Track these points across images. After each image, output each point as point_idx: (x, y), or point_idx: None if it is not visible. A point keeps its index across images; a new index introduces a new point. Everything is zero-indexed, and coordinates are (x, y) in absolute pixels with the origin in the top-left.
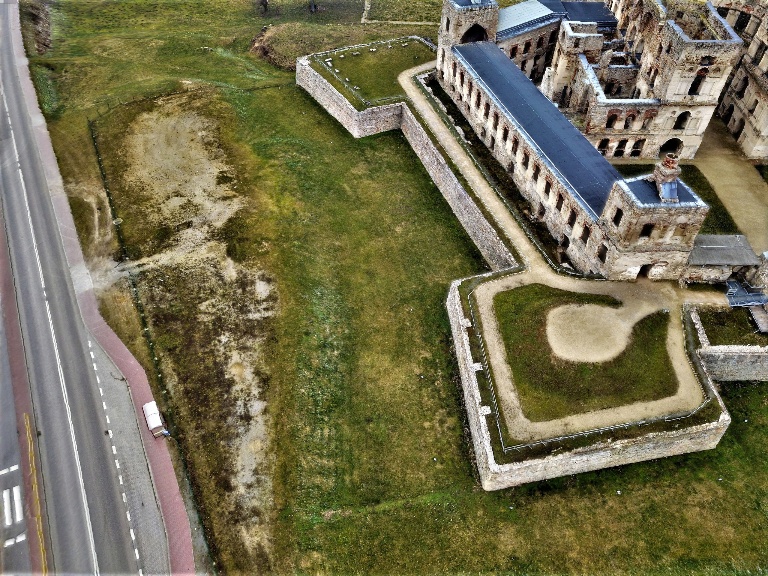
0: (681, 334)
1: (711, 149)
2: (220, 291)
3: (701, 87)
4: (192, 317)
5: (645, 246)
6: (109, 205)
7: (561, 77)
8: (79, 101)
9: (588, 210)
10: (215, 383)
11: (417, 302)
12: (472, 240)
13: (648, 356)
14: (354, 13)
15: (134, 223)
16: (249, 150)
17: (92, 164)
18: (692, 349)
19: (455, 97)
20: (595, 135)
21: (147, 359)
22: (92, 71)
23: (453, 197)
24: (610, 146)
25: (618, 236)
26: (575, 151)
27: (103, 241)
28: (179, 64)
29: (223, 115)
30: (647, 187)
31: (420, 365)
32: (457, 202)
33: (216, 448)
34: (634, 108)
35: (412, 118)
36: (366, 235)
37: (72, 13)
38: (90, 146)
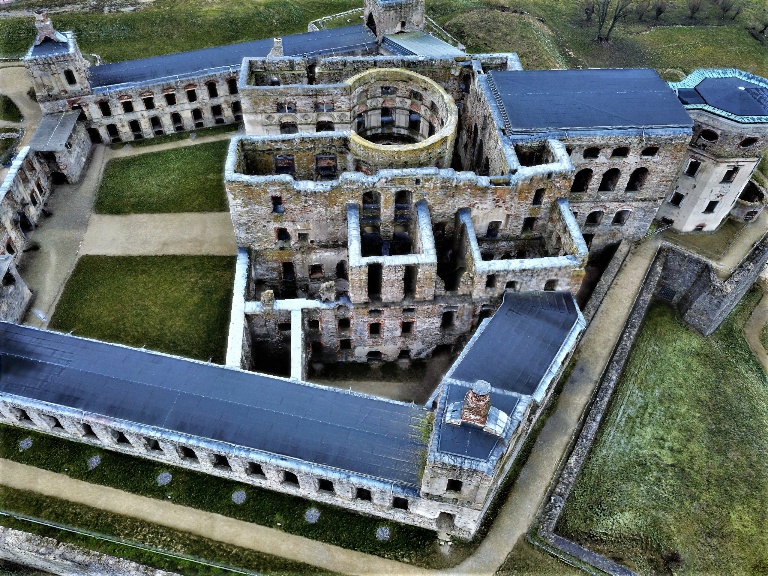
0: (1, 126)
1: None
2: None
3: None
4: None
5: None
6: None
7: None
8: None
9: None
10: None
11: None
12: None
13: None
14: (609, 63)
15: None
16: None
17: None
18: None
19: None
20: None
21: None
22: None
23: None
24: None
25: None
26: (175, 64)
27: None
28: None
29: None
30: None
31: None
32: None
33: (23, 6)
34: None
35: None
36: (184, 48)
37: None
38: None
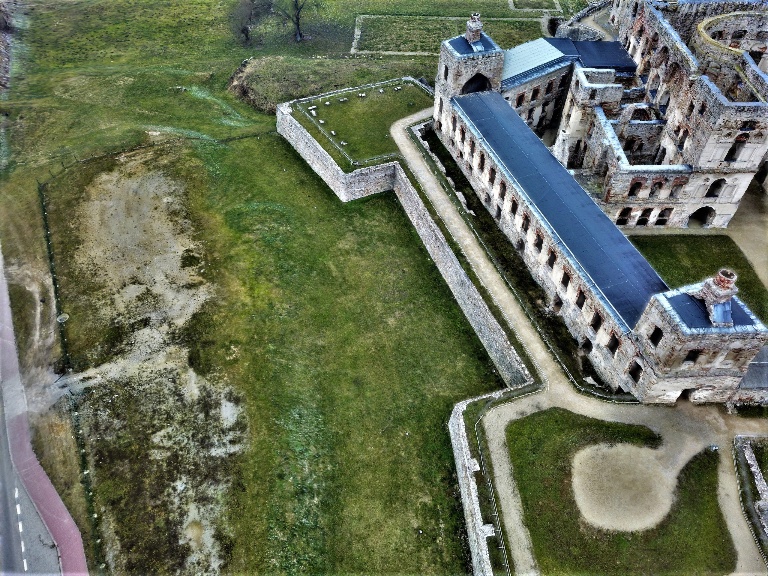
0: (735, 481)
1: (746, 215)
2: (178, 416)
3: (739, 153)
4: (143, 454)
5: (689, 371)
6: (54, 296)
7: (574, 131)
8: (33, 155)
9: (617, 317)
10: (166, 552)
11: (414, 423)
12: (477, 336)
13: (697, 516)
14: (343, 42)
15: (82, 320)
16: (220, 221)
17: (39, 240)
18: (749, 502)
19: (455, 153)
20: (616, 204)
21: (85, 516)
22: (51, 117)
23: (454, 281)
24: (632, 215)
25: (656, 358)
26: (598, 237)
27: (44, 345)
28: (148, 107)
29: (192, 176)
30: (693, 305)
31: (418, 514)
32: (459, 288)
33: None
34: (661, 176)
35: (406, 181)
36: (354, 330)
37: (36, 44)
38: (39, 216)
